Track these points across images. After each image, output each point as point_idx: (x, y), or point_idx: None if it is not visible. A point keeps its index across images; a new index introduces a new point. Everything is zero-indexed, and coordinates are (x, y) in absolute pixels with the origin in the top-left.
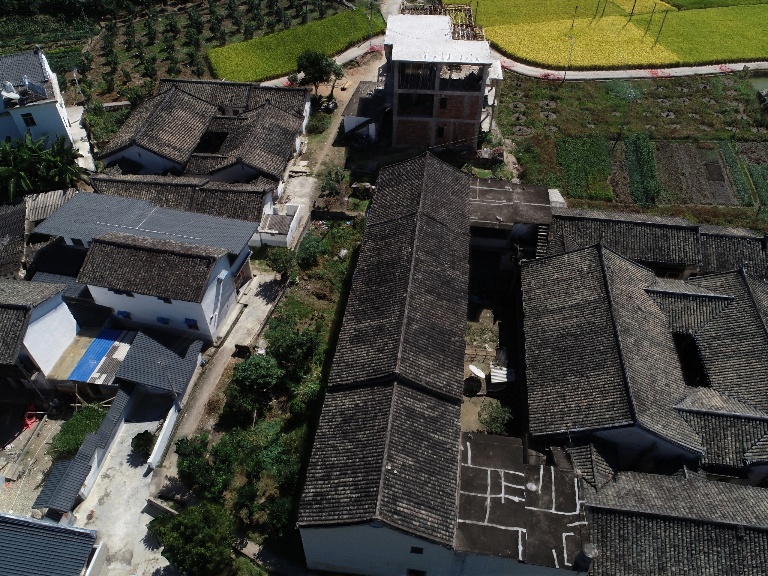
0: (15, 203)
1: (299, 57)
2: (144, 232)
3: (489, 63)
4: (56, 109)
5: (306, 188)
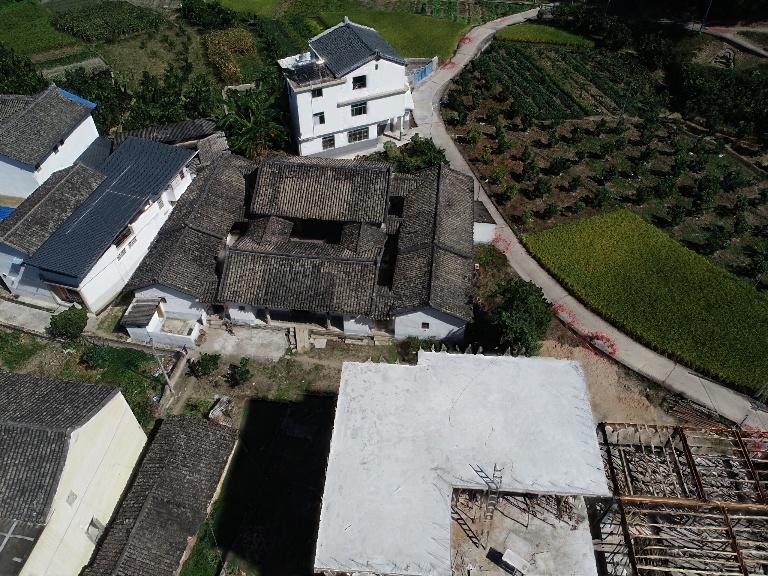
0: (216, 128)
1: (511, 279)
2: (99, 196)
3: (316, 560)
4: (296, 97)
5: (256, 350)
